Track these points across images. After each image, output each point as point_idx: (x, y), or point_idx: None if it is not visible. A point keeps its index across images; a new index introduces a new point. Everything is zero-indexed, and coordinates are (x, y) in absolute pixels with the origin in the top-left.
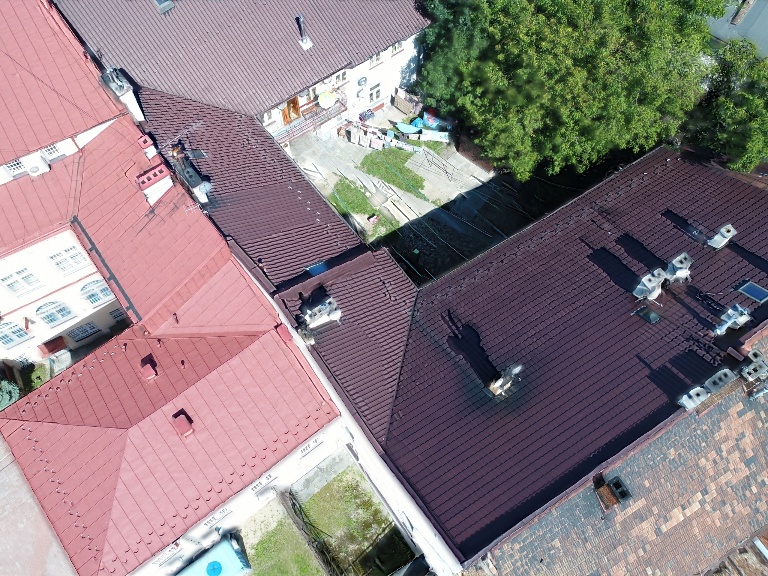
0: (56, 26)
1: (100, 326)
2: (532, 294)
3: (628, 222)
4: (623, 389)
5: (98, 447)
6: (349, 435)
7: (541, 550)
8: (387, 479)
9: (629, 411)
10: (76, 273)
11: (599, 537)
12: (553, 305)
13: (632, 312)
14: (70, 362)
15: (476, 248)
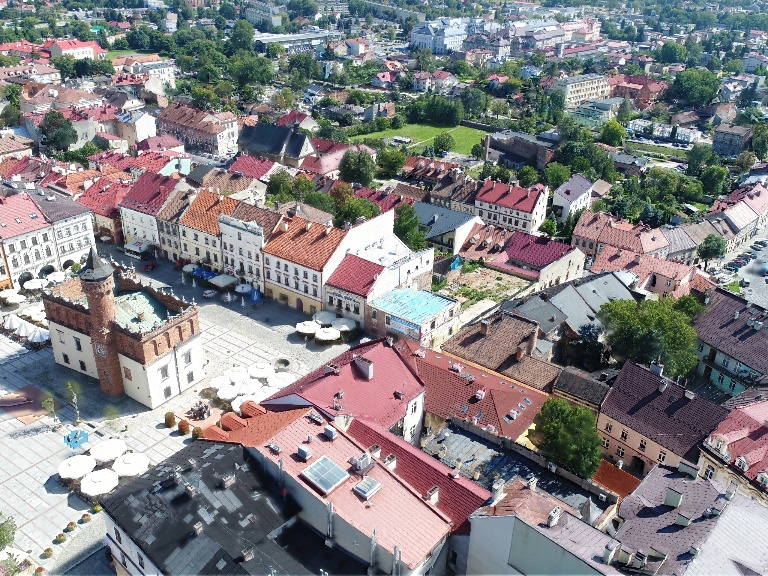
0: (749, 407)
1: None
2: None
3: (726, 335)
4: None
5: None
6: None
7: None
8: None
9: None
10: None
11: None
12: None
13: (765, 330)
14: None
15: (705, 396)
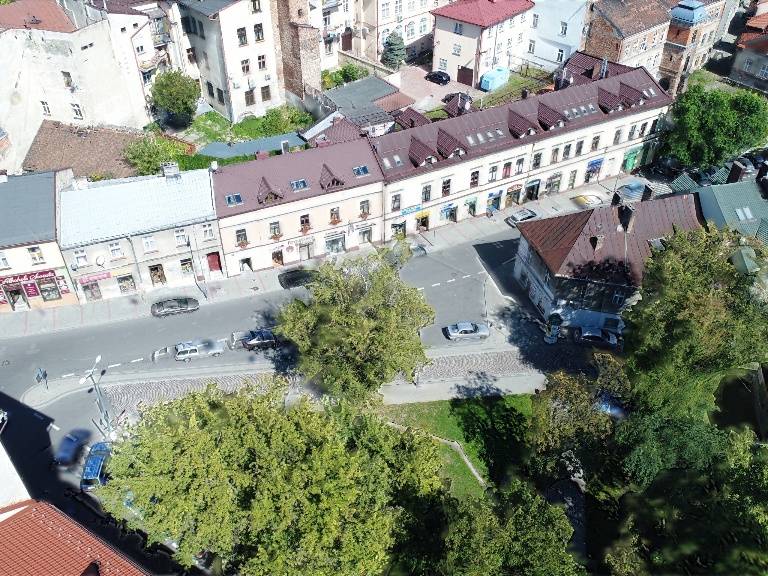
0: None
1: (417, 51)
2: None
3: None
4: None
5: (470, 6)
6: (534, 27)
7: (608, 7)
8: (558, 3)
9: None
10: (423, 9)
11: (623, 8)
12: None
13: None
14: (407, 64)
15: None
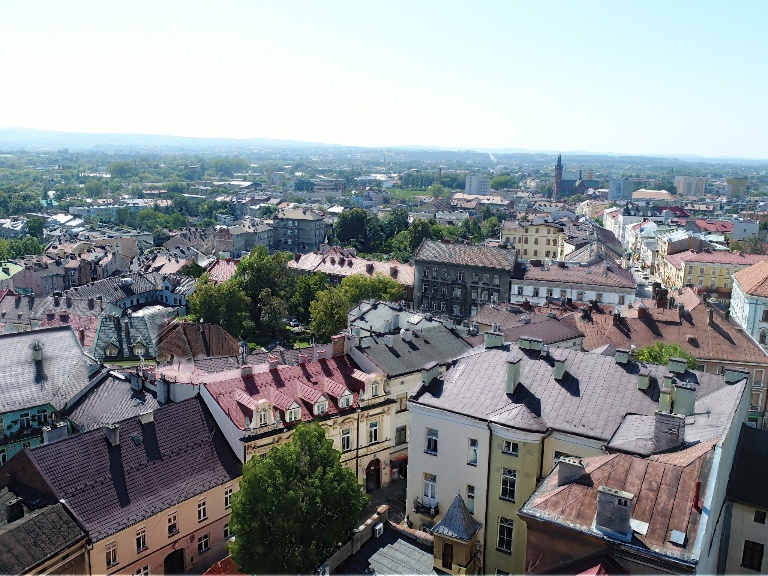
0: None
1: None
2: (6, 386)
3: None
4: (1, 347)
5: None
6: None
7: None
8: None
9: (4, 342)
10: None
11: None
12: (2, 379)
13: None
14: None
15: None
